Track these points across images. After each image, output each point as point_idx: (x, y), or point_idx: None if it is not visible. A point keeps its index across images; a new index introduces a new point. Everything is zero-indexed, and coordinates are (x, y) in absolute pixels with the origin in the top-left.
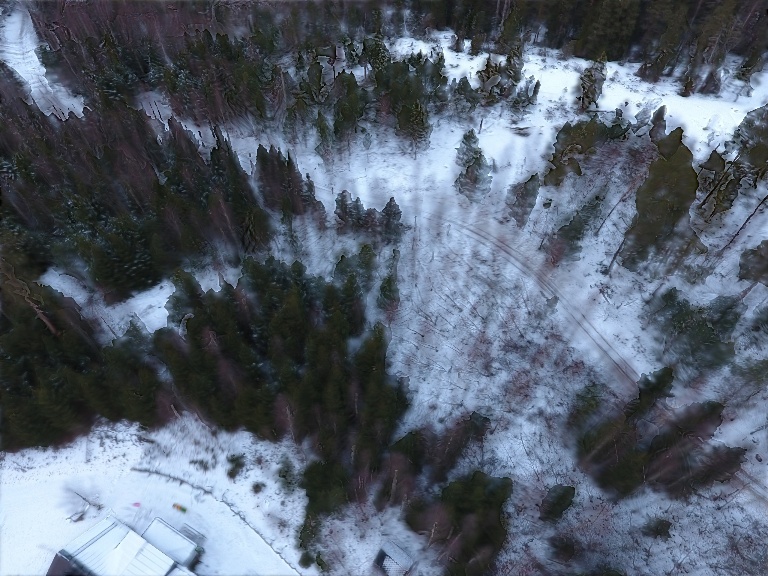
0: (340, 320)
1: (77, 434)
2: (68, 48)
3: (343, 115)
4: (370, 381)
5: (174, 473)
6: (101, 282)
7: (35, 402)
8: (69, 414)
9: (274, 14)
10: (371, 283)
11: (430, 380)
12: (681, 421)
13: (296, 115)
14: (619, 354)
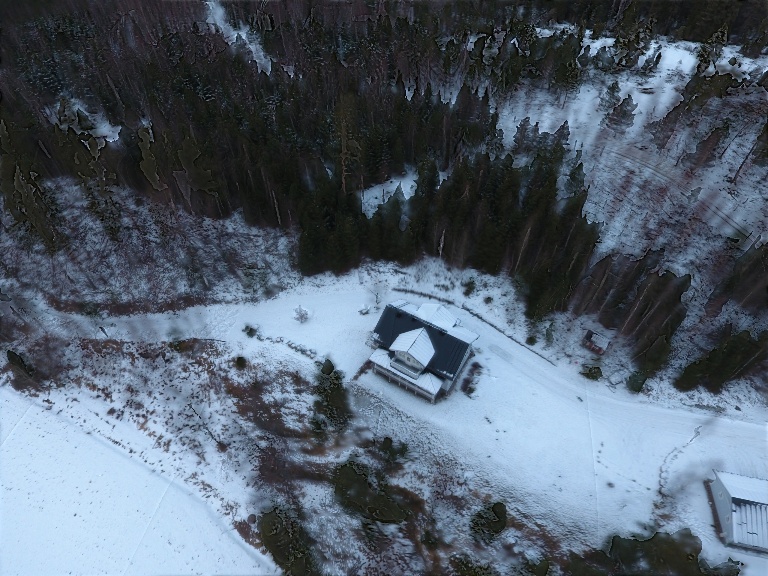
0: None
1: (350, 267)
2: (285, 27)
3: (513, 70)
4: (578, 222)
5: (425, 291)
6: (363, 169)
7: (340, 233)
8: (358, 245)
9: (431, 7)
10: (557, 175)
11: (605, 241)
12: None
13: (475, 71)
14: (748, 231)
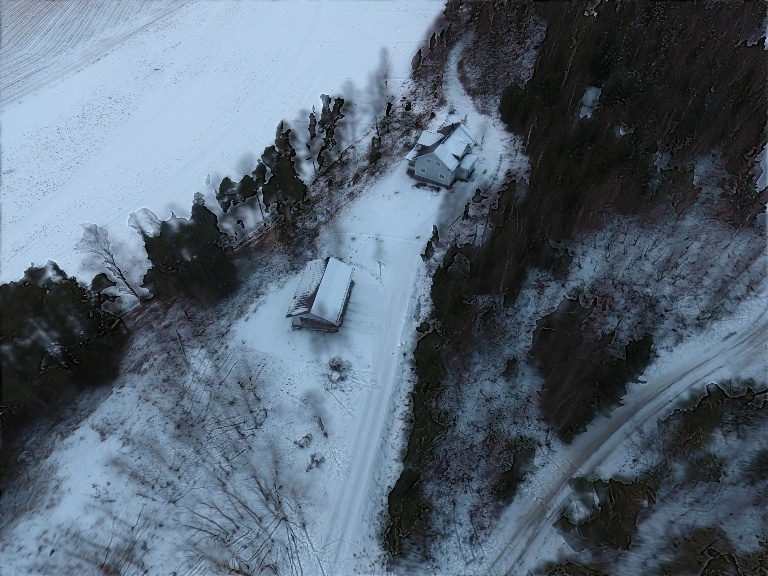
0: (611, 159)
1: (514, 132)
2: None
3: None
4: None
5: (502, 166)
6: (601, 93)
7: None
8: (521, 115)
9: None
10: None
11: (596, 251)
12: None
13: None
14: (684, 393)
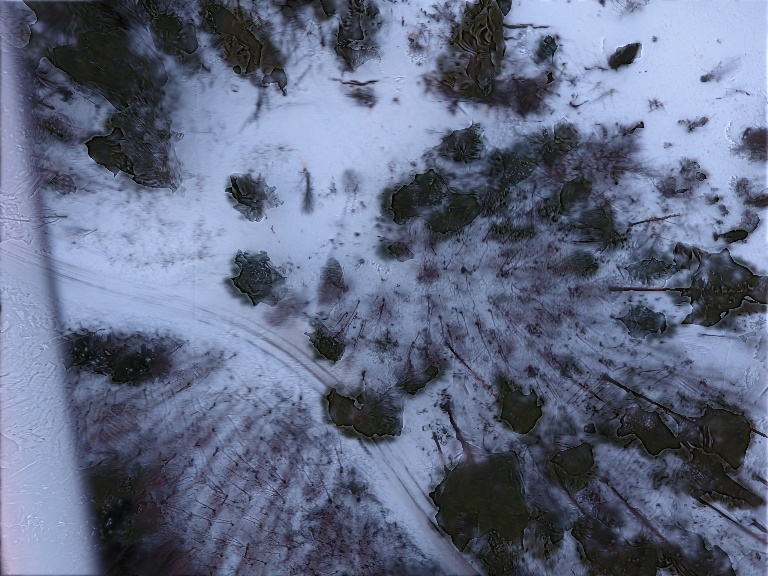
0: None
1: None
2: None
3: None
4: None
5: None
6: None
7: None
8: None
9: None
10: None
11: (228, 555)
12: None
13: None
14: None
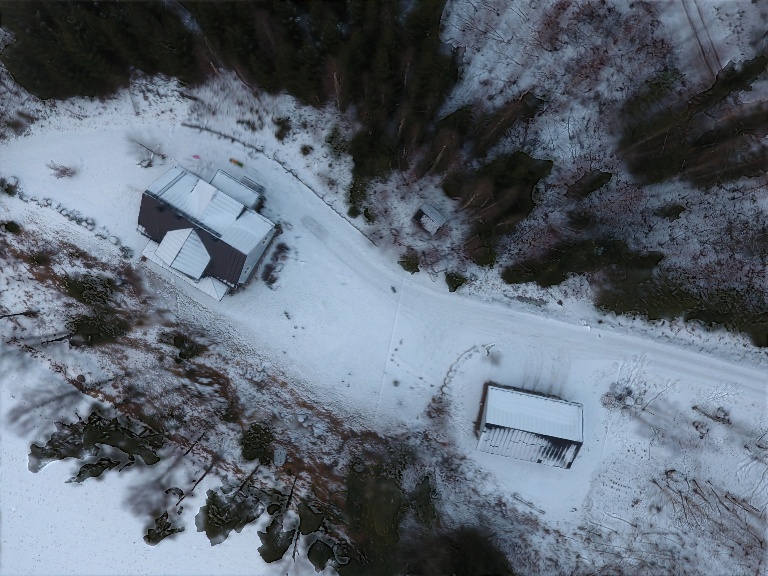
0: None
1: (117, 86)
2: None
3: None
4: (423, 49)
5: (224, 131)
6: None
7: (63, 48)
8: (103, 64)
9: None
10: None
11: (485, 51)
12: (746, 118)
13: None
14: (709, 33)
